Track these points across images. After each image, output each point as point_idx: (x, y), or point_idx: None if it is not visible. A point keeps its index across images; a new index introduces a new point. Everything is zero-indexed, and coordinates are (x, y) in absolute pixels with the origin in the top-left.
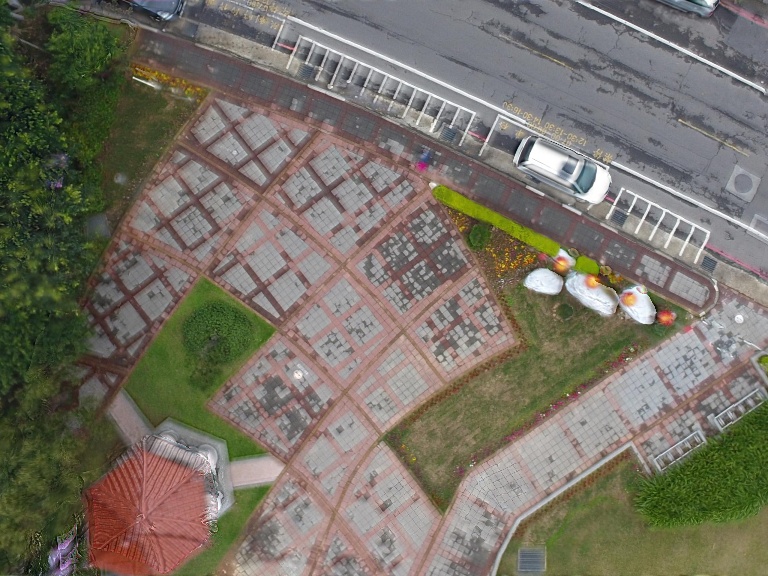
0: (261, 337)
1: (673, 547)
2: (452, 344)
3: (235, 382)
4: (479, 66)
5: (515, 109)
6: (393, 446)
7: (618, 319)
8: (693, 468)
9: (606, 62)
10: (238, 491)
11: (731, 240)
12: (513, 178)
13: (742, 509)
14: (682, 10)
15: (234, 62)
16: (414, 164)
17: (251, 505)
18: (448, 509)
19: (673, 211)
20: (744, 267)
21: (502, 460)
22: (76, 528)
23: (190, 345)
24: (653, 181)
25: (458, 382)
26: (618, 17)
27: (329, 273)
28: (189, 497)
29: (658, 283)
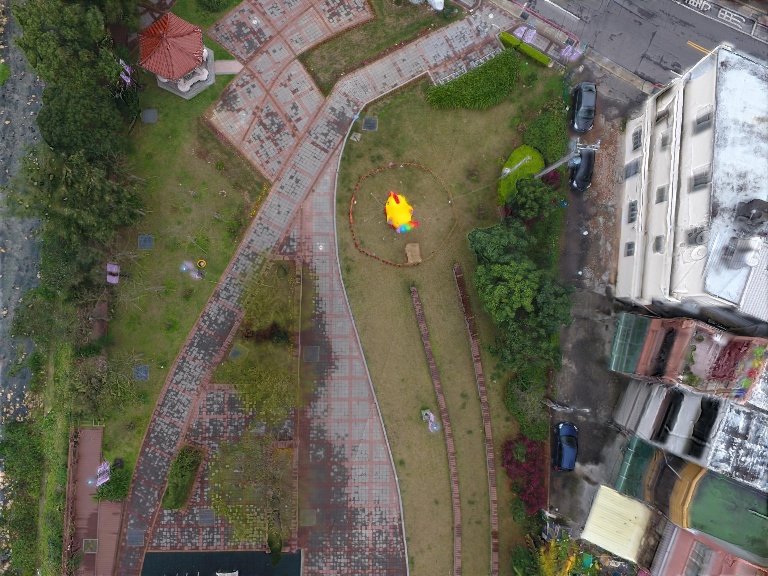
0: (237, 1)
1: (443, 119)
2: (337, 14)
3: (221, 23)
4: None
5: None
6: (301, 62)
7: (427, 10)
8: (457, 80)
9: None
10: (217, 77)
11: None
12: None
13: (480, 100)
14: None
15: None
16: None
17: (223, 85)
18: (328, 97)
19: None
20: None
21: (359, 75)
22: (130, 72)
23: None
24: None
25: (339, 33)
26: None
27: None
28: (189, 42)
29: None
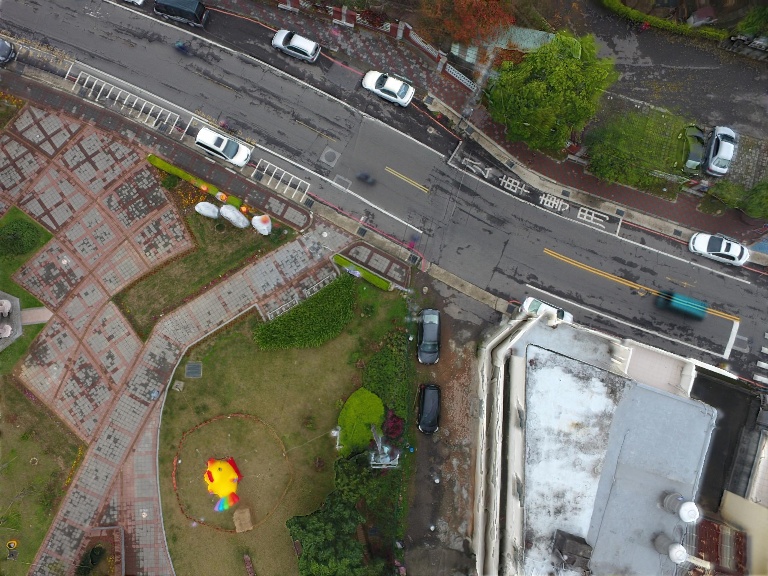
0: (44, 240)
1: (271, 363)
2: (154, 246)
3: (27, 266)
4: (183, 89)
5: (202, 114)
6: (116, 304)
7: (253, 233)
8: (285, 317)
9: (256, 88)
10: (24, 328)
11: (321, 189)
12: (198, 152)
13: (309, 340)
14: (299, 58)
15: (42, 86)
16: (141, 144)
17: (31, 336)
18: (146, 341)
19: (289, 172)
20: (329, 204)
21: (180, 313)
22: None
23: (1, 243)
24: (279, 155)
25: (157, 268)
26: (264, 62)
27: (86, 204)
28: None
29: (277, 213)
